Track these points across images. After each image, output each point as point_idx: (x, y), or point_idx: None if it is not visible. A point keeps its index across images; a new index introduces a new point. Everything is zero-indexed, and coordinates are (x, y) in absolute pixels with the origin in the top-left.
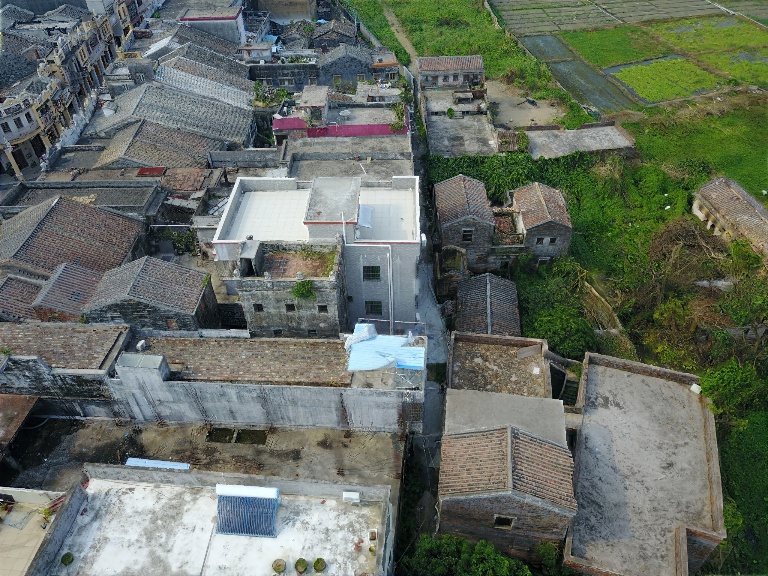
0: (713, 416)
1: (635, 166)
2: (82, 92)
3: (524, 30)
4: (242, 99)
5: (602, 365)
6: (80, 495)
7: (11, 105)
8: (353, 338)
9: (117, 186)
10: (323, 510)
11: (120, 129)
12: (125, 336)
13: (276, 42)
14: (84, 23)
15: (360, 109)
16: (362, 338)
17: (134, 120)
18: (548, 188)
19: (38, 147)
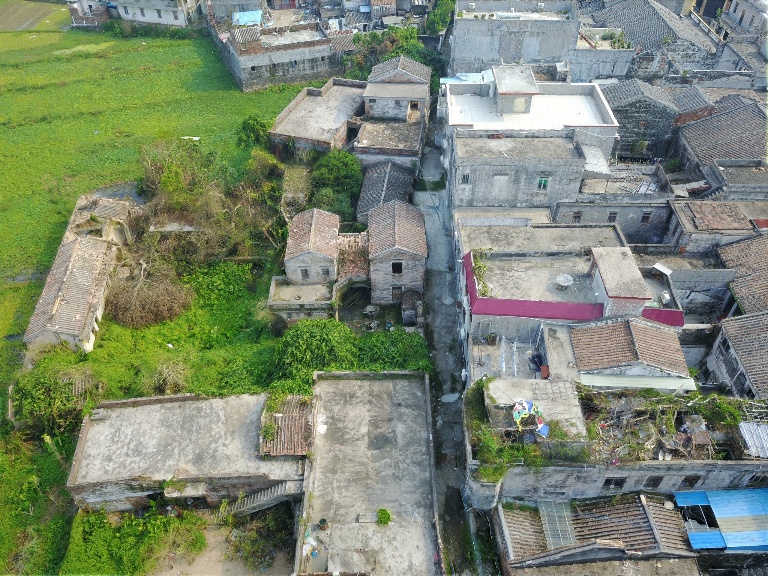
0: None
1: None
2: None
3: None
4: None
5: None
6: None
7: None
8: None
9: None
10: None
11: None
12: None
13: None
14: None
15: None
16: None
17: None
18: None
19: None
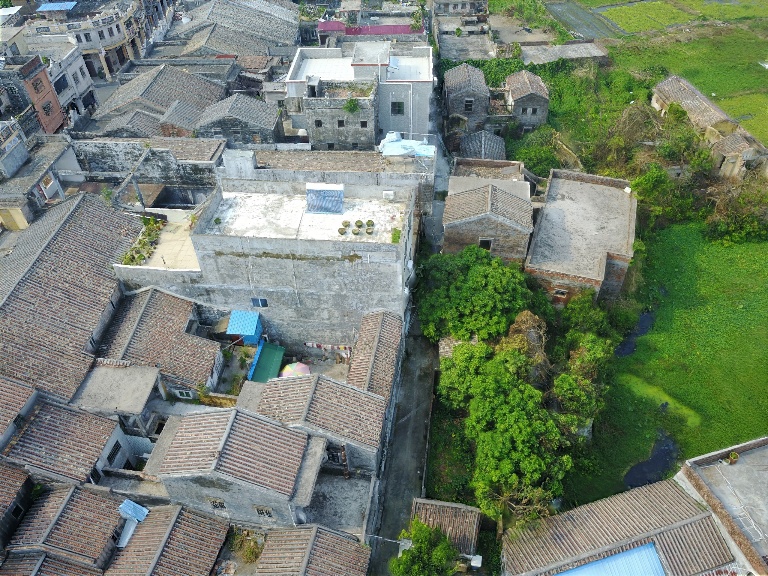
0: (636, 201)
1: (608, 72)
2: (148, 21)
3: None
4: (289, 16)
5: (563, 178)
6: (220, 195)
7: (106, 16)
8: (385, 139)
9: (203, 64)
10: (371, 204)
11: (197, 31)
12: (224, 145)
13: None
14: None
15: (386, 18)
16: (392, 139)
17: (208, 24)
18: (533, 75)
19: (121, 58)
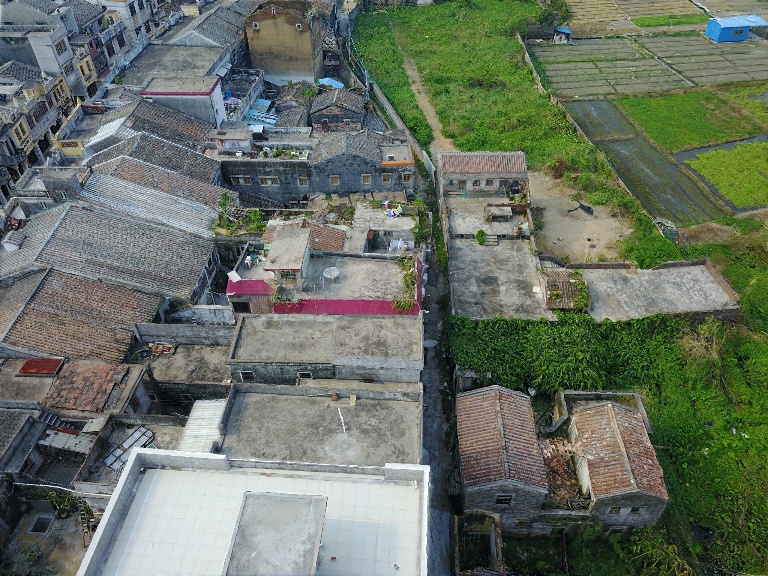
0: None
1: (738, 335)
2: None
3: (572, 92)
4: (202, 219)
5: None
6: None
7: None
8: None
9: None
10: None
11: (20, 278)
12: None
13: (269, 108)
14: (25, 91)
15: (354, 260)
16: None
17: (37, 268)
18: (626, 410)
19: None
